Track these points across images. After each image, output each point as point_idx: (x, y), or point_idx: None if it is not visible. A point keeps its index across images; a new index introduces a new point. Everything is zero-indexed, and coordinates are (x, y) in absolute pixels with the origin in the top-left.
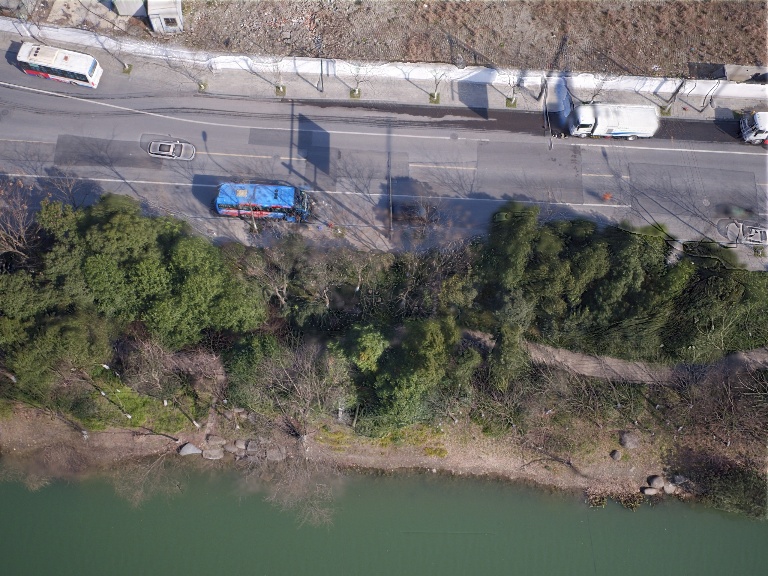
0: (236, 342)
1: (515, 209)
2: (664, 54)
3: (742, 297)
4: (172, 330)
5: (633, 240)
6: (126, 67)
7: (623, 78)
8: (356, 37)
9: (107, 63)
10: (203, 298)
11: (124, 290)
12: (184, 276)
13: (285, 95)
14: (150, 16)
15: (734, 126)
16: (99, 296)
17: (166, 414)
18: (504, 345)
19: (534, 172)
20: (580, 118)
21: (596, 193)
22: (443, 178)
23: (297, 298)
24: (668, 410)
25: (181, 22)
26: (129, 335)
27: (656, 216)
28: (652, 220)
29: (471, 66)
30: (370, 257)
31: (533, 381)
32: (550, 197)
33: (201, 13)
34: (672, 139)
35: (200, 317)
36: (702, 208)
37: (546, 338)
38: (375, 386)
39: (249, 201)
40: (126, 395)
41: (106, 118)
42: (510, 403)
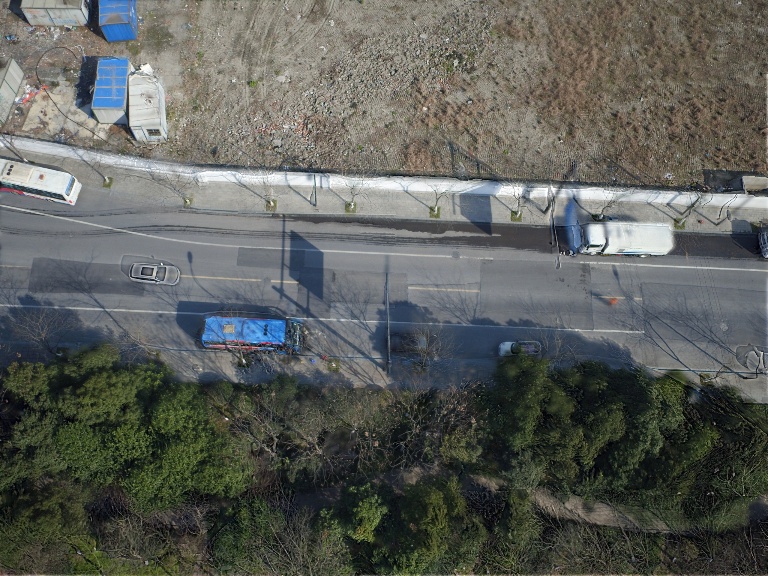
0: (221, 511)
1: (521, 337)
2: (677, 160)
3: (765, 446)
4: (152, 496)
5: (651, 403)
6: (106, 181)
7: (635, 191)
8: (351, 145)
9: (86, 176)
10: (186, 465)
11: (100, 457)
12: (165, 444)
13: (276, 210)
14: (132, 128)
15: (752, 240)
16: (72, 465)
17: (147, 574)
18: (512, 518)
19: (541, 294)
20: (590, 238)
21: (607, 317)
22: (444, 302)
23: (288, 446)
24: (686, 564)
25: (165, 131)
26: (106, 501)
27: (671, 343)
28: (667, 347)
29: (474, 180)
30: (367, 395)
31: (541, 533)
32: (558, 322)
33: (187, 119)
34: (687, 255)
35: (183, 483)
36: (719, 333)
37: (555, 488)
38: (372, 561)
39: (237, 338)
40: (104, 554)
41: (85, 238)
42: (517, 558)
